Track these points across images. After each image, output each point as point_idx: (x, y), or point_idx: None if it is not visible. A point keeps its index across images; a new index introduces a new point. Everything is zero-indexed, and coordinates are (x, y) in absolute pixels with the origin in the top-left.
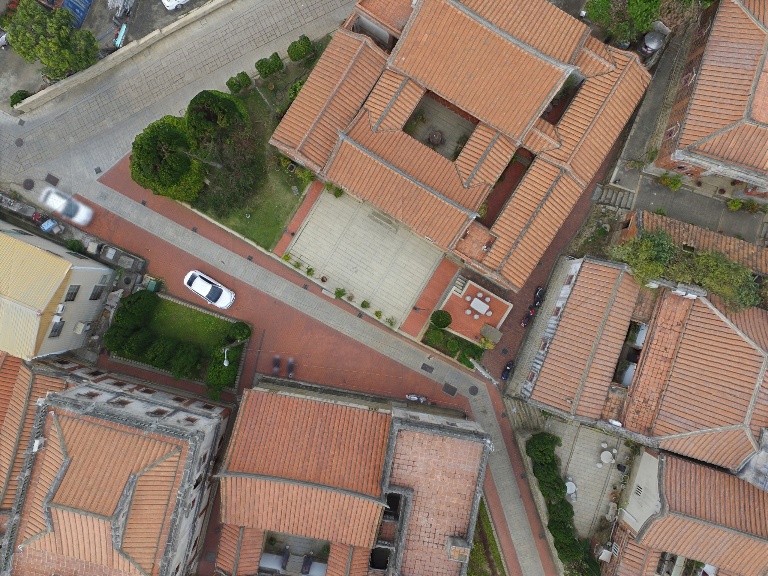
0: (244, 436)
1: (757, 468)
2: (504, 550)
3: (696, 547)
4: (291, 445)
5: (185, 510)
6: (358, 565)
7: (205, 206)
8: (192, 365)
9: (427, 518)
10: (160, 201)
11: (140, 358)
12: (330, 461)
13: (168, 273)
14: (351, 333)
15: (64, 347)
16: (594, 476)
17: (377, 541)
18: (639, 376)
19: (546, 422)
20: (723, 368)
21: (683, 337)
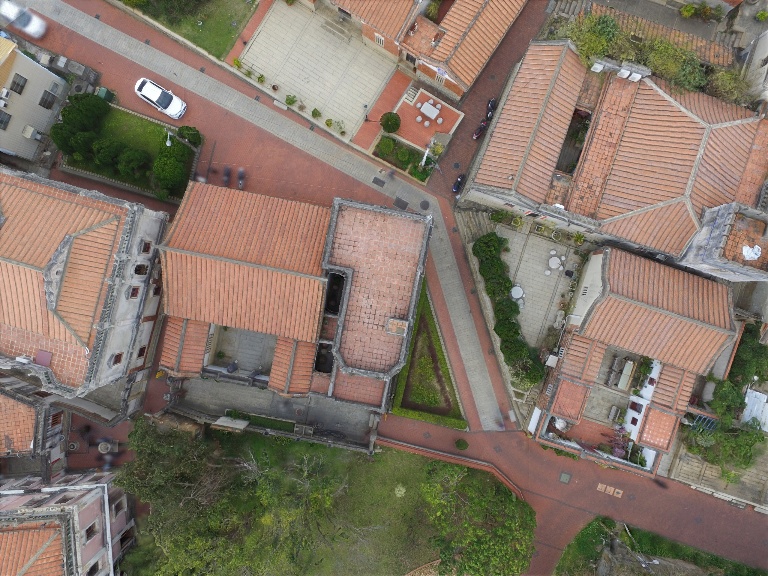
0: (186, 221)
1: (698, 244)
2: (453, 365)
3: (639, 337)
4: (234, 231)
5: (123, 283)
6: (302, 363)
7: (156, 11)
8: (139, 164)
9: (367, 299)
10: (114, 14)
11: (90, 168)
12: (272, 247)
13: (120, 86)
14: (302, 146)
15: (12, 148)
16: (542, 284)
17: (321, 337)
18: (583, 160)
19: (495, 229)
20: (666, 145)
21: (628, 120)
